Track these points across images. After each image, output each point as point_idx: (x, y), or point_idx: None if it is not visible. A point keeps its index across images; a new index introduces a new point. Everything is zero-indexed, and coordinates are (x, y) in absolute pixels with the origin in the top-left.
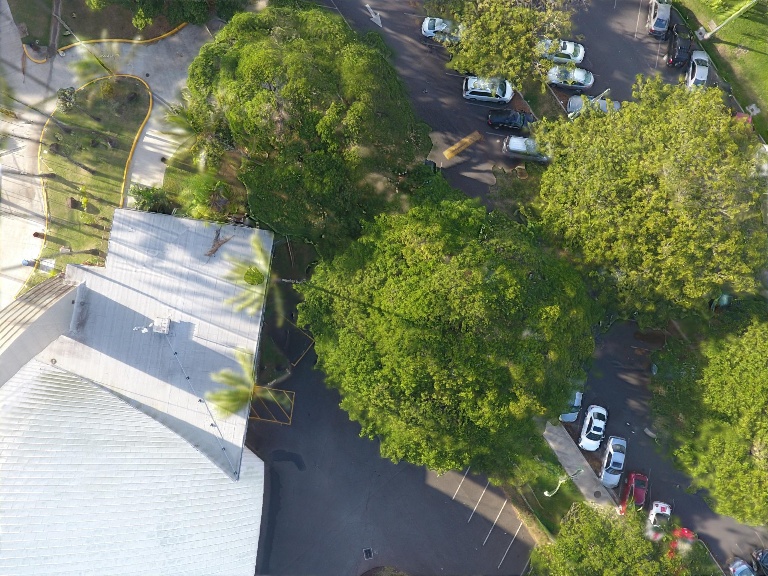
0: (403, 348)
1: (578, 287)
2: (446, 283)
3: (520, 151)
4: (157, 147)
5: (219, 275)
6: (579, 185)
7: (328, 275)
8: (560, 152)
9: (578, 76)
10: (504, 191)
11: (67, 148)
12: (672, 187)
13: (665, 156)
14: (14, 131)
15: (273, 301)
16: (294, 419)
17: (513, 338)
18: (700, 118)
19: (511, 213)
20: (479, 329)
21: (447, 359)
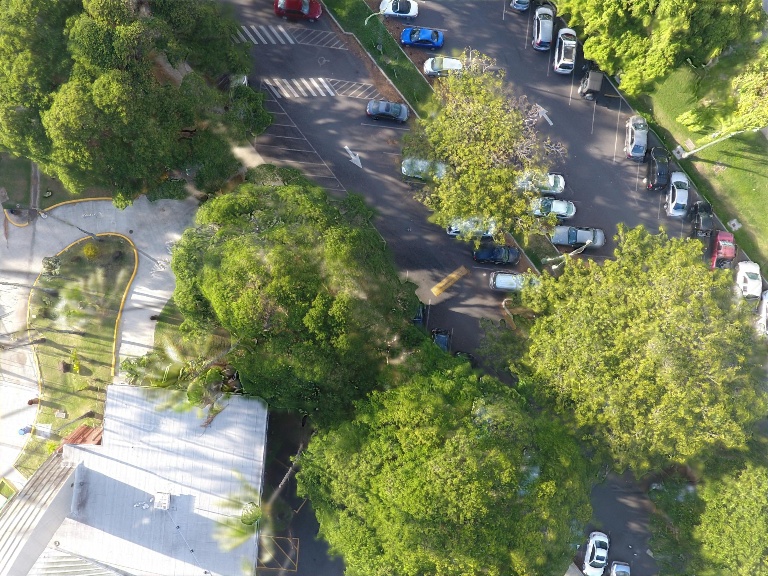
0: (403, 539)
1: (572, 453)
2: (442, 473)
3: (507, 288)
4: (145, 304)
5: (216, 445)
6: (567, 354)
7: (324, 449)
8: (546, 308)
9: (560, 208)
10: (494, 345)
11: (55, 311)
12: (659, 360)
13: (650, 332)
14: (1, 297)
15: (271, 450)
16: (300, 565)
17: (511, 520)
18: (682, 284)
19: (502, 368)
20: (477, 519)
21: (448, 549)
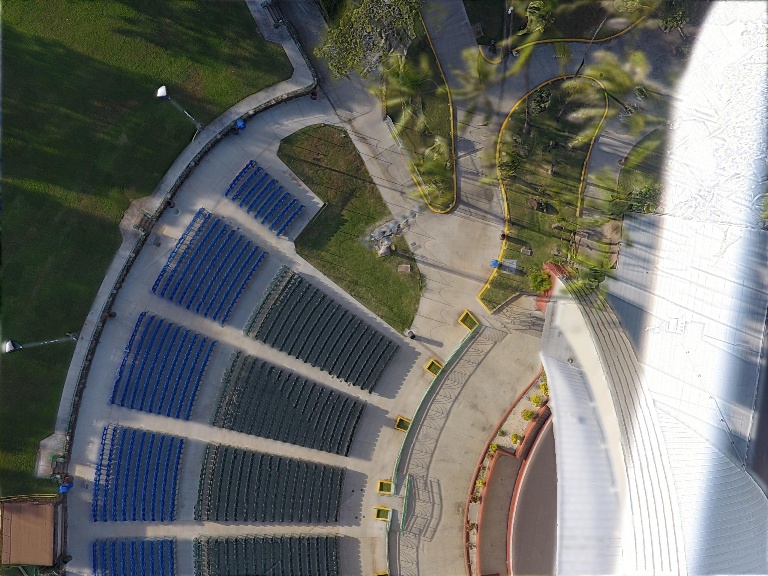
0: None
1: None
2: None
3: None
4: (612, 148)
5: (728, 276)
6: None
7: None
8: None
9: None
10: None
11: (526, 150)
12: None
13: None
14: (471, 133)
15: None
16: None
17: None
18: None
19: None
20: None
21: None
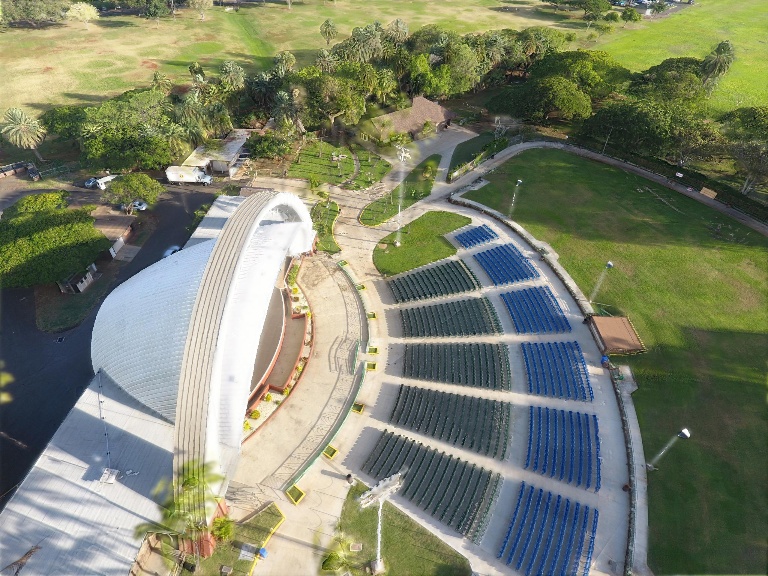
0: None
1: None
2: None
3: None
4: None
5: (37, 526)
6: None
7: None
8: None
9: None
10: None
11: None
12: None
13: None
14: None
15: None
16: None
17: None
18: None
19: None
20: None
21: None
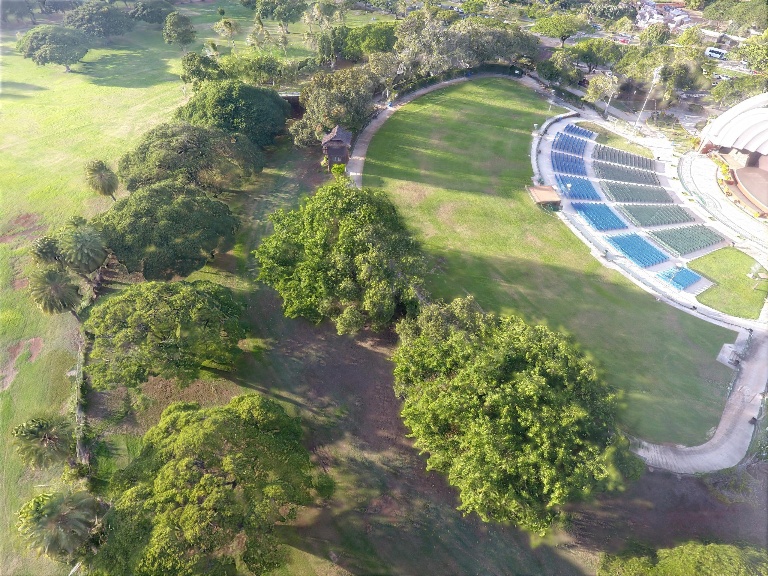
0: None
1: None
2: None
3: None
4: None
5: None
6: None
7: None
8: None
9: None
10: None
11: None
12: None
13: None
14: None
15: None
16: None
17: None
18: None
19: None
20: None
21: None
